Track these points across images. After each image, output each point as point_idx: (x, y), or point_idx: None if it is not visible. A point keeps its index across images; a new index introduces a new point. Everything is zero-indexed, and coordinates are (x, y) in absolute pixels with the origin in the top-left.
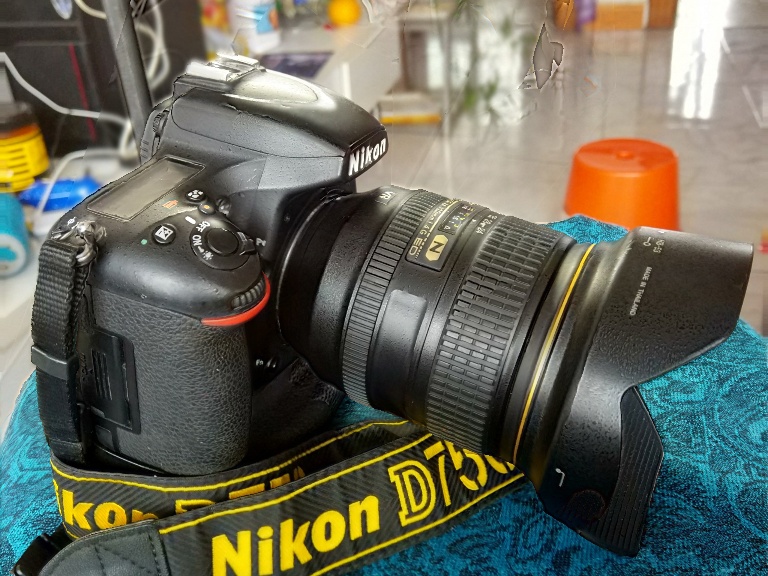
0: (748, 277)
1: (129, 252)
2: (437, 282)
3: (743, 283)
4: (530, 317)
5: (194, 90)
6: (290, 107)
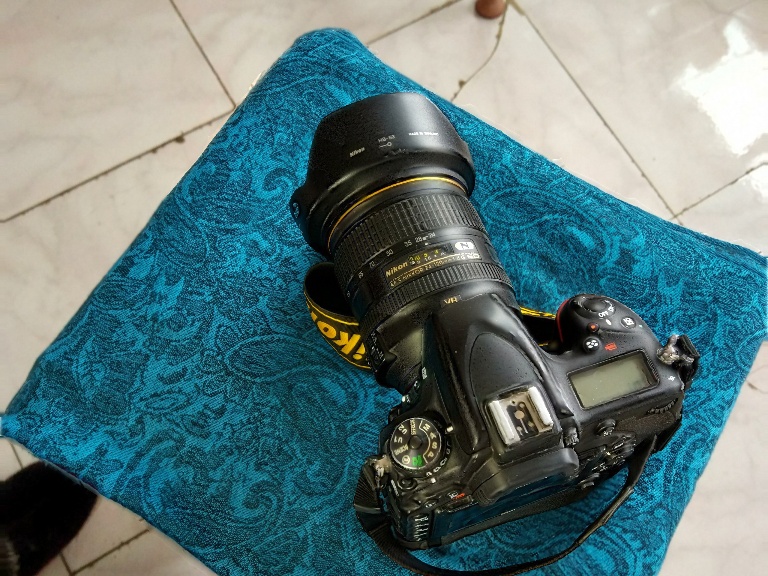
0: (385, 94)
1: (650, 331)
2: (477, 240)
3: (391, 95)
4: (453, 192)
5: (558, 403)
6: (510, 332)
